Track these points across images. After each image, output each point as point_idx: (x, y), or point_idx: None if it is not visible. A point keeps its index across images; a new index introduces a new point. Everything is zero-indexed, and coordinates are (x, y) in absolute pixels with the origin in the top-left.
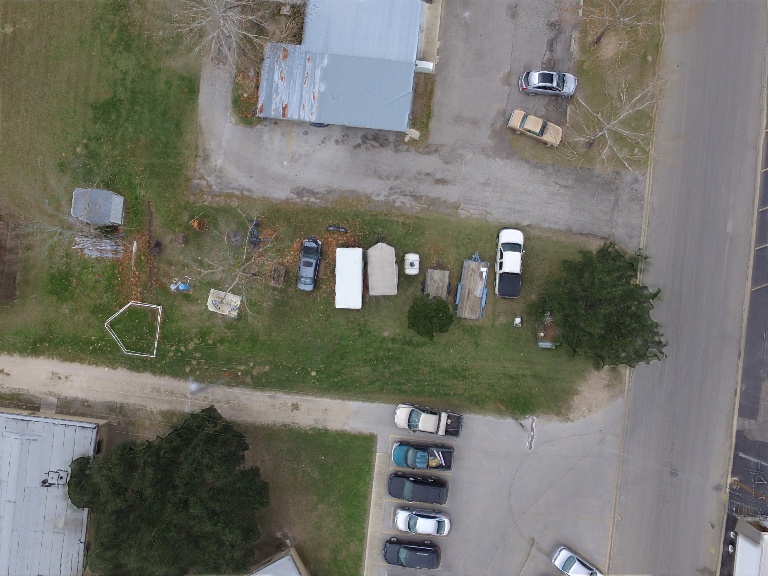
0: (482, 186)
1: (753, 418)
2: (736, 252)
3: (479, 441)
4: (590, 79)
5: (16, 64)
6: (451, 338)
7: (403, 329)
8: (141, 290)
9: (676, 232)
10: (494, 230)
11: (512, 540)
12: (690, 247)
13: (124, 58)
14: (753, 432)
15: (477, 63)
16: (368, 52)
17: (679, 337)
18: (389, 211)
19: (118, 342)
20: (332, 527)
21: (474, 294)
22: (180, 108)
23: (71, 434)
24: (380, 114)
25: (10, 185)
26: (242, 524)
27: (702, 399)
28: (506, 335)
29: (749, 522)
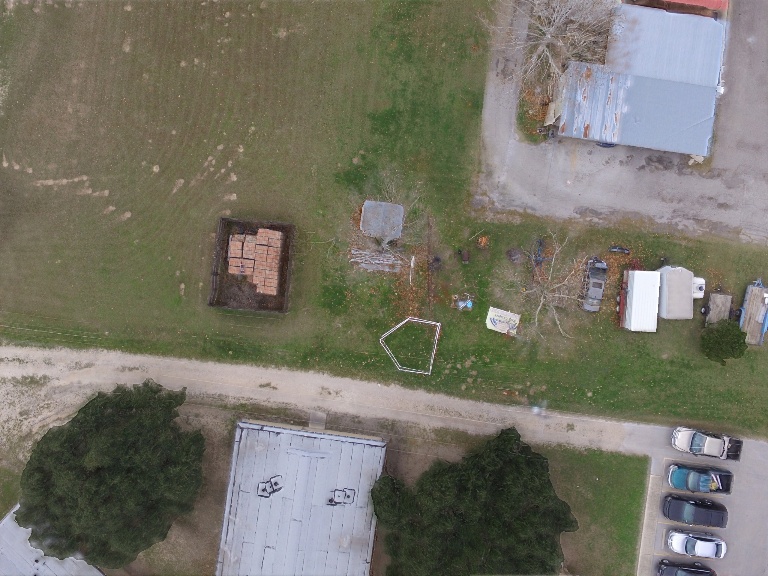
0: (763, 212)
1: None
2: None
3: (751, 465)
4: None
5: (289, 70)
6: (728, 362)
7: (682, 352)
8: (418, 306)
9: None
10: None
11: None
12: None
13: (404, 69)
14: None
15: (759, 89)
16: (671, 75)
17: None
18: (672, 234)
19: (392, 358)
20: (605, 548)
21: (755, 319)
22: (463, 122)
23: (359, 452)
24: (682, 138)
25: (282, 194)
26: None
27: None
28: None
29: None
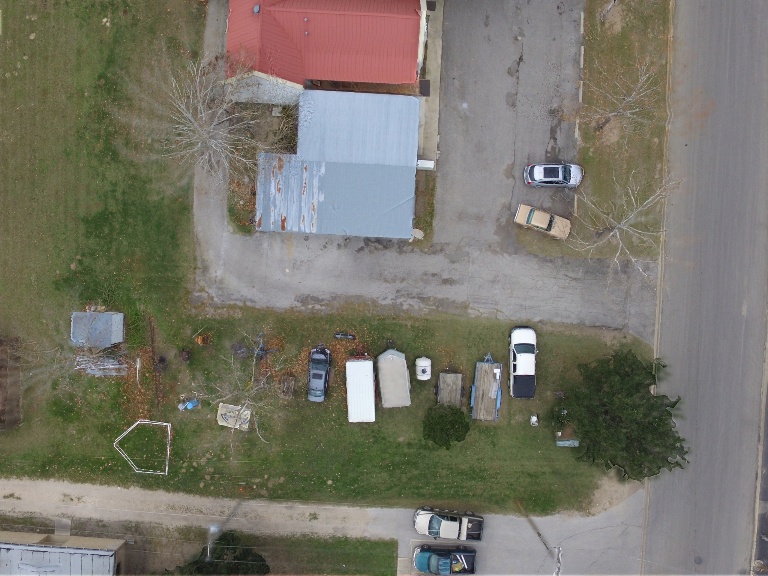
0: (491, 283)
1: None
2: (752, 334)
3: (500, 540)
4: (597, 165)
5: (1, 180)
6: (467, 439)
7: (418, 433)
8: (148, 408)
9: (691, 318)
10: (505, 328)
11: None
12: (705, 332)
13: (113, 169)
14: None
15: (479, 155)
16: (367, 157)
17: (698, 424)
18: (397, 315)
19: (128, 461)
20: None
21: (488, 395)
22: (175, 219)
23: (88, 563)
24: (383, 222)
25: (5, 306)
26: None
27: (723, 485)
28: (523, 433)
29: None
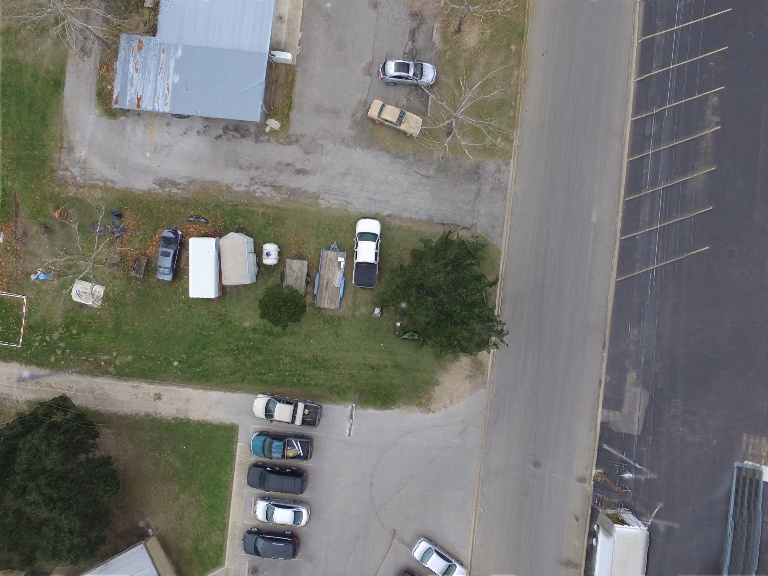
0: (342, 176)
1: (618, 410)
2: (601, 242)
3: (340, 431)
4: (452, 68)
5: None
6: (311, 328)
7: (263, 319)
8: (7, 280)
9: (539, 222)
10: (354, 220)
11: (373, 531)
12: (553, 237)
13: None
14: (618, 424)
15: (339, 53)
16: (222, 43)
17: (542, 327)
18: (250, 201)
19: None
20: (193, 517)
21: (332, 284)
22: (46, 100)
23: None
24: (233, 104)
25: None
26: (82, 511)
27: (565, 390)
28: (366, 325)
29: (607, 515)
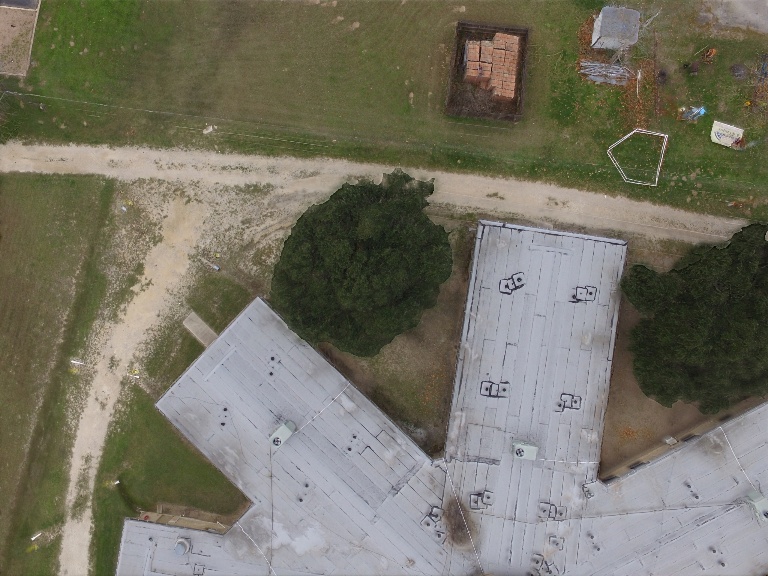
0: None
1: None
2: None
3: None
4: None
5: None
6: None
7: None
8: (645, 118)
9: None
10: None
11: None
12: None
13: None
14: None
15: None
16: None
17: None
18: None
19: (619, 170)
20: None
21: None
22: None
23: (601, 250)
24: None
25: (511, 8)
26: None
27: None
28: None
29: None
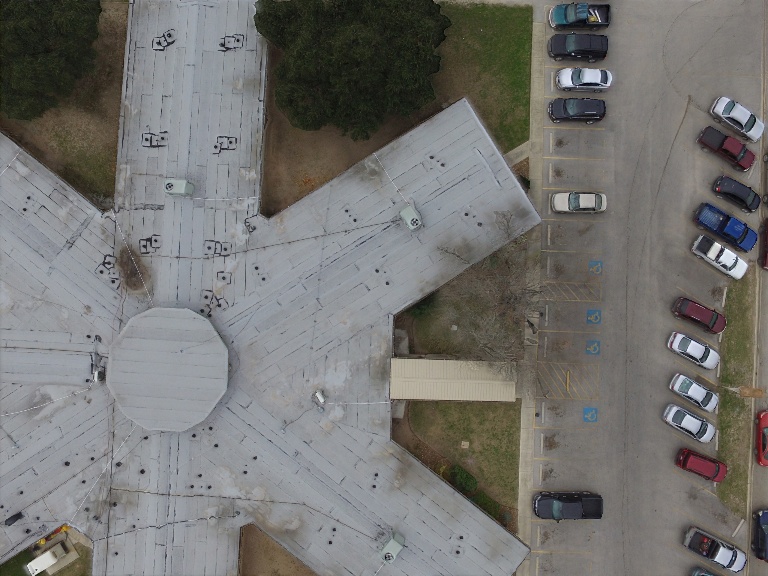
0: None
1: None
2: None
3: (630, 6)
4: None
5: None
6: None
7: None
8: None
9: None
10: None
11: (669, 98)
12: None
13: None
14: None
15: None
16: None
17: None
18: None
19: None
20: (495, 94)
21: None
22: None
23: None
24: None
25: None
26: None
27: None
28: None
29: None
